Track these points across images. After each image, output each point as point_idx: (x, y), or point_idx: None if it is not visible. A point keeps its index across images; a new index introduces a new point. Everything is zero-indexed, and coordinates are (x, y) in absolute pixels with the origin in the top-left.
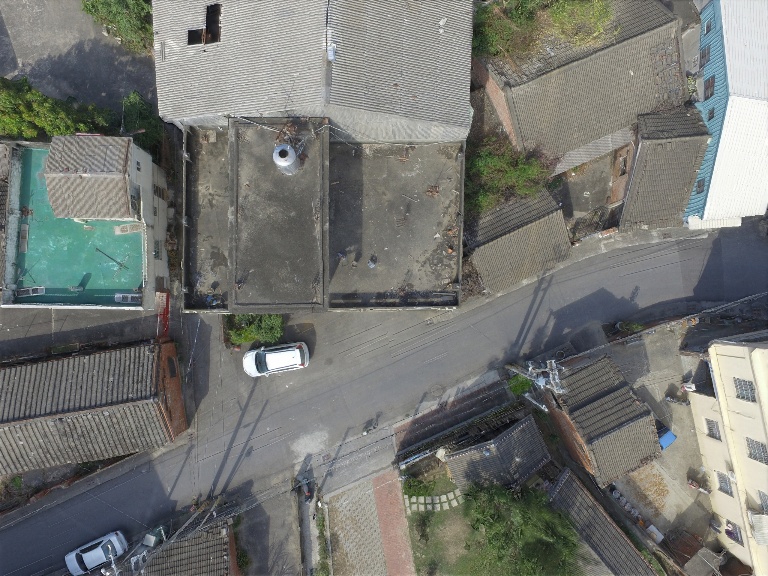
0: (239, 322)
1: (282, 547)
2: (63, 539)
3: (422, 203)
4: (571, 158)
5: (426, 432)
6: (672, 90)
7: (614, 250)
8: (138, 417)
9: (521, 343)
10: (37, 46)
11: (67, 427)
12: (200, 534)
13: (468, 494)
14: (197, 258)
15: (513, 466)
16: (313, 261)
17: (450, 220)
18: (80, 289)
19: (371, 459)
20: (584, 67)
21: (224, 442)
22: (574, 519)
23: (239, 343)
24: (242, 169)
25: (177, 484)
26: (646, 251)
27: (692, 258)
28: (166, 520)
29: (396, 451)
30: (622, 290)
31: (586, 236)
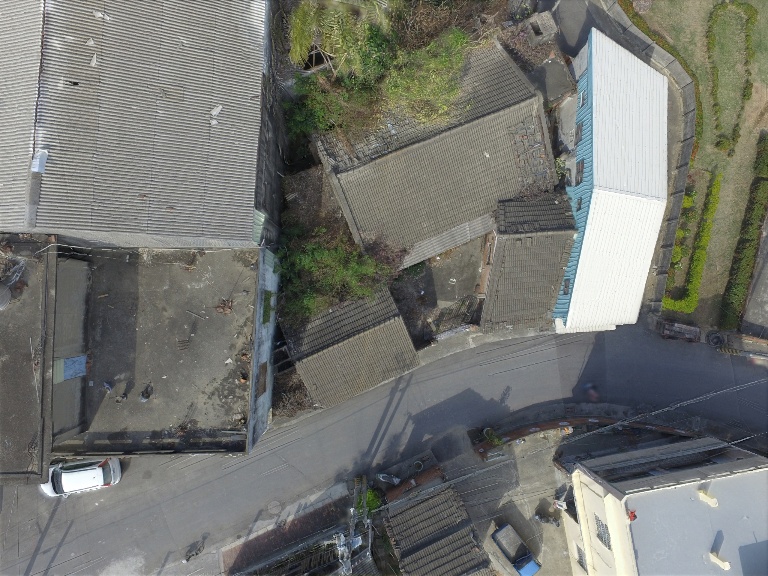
0: None
1: None
2: None
3: (211, 321)
4: (422, 249)
5: None
6: (538, 173)
7: (484, 345)
8: None
9: (374, 452)
10: None
11: None
12: None
13: None
14: None
15: None
16: (30, 418)
17: (245, 342)
18: None
19: None
20: (428, 149)
21: (19, 571)
22: None
23: None
24: None
25: None
26: (520, 346)
27: (571, 354)
28: None
29: None
30: (491, 391)
31: None
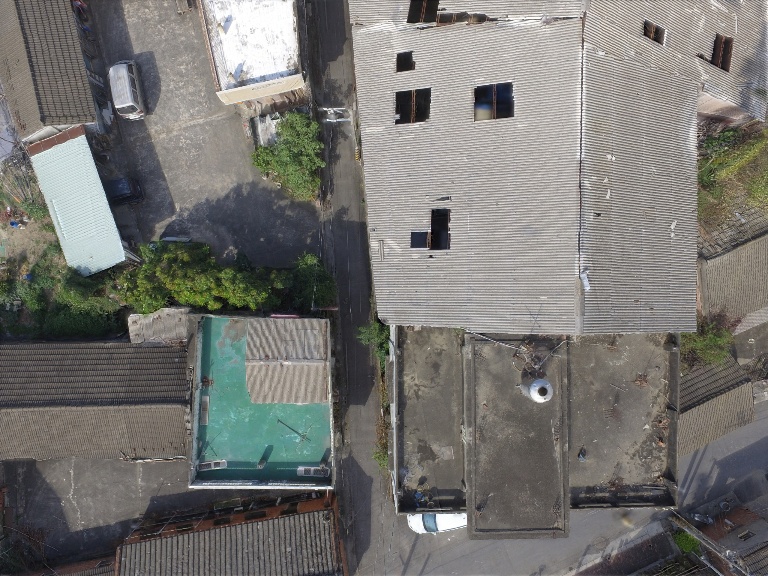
0: None
1: None
2: None
3: (631, 393)
4: (751, 318)
5: None
6: None
7: None
8: None
9: (684, 493)
10: (194, 190)
11: None
12: None
13: None
14: (404, 452)
15: None
16: (553, 484)
17: (659, 410)
18: (264, 464)
19: None
20: None
21: None
22: None
23: None
24: (479, 388)
25: None
26: None
27: None
28: None
29: None
30: None
31: (760, 392)
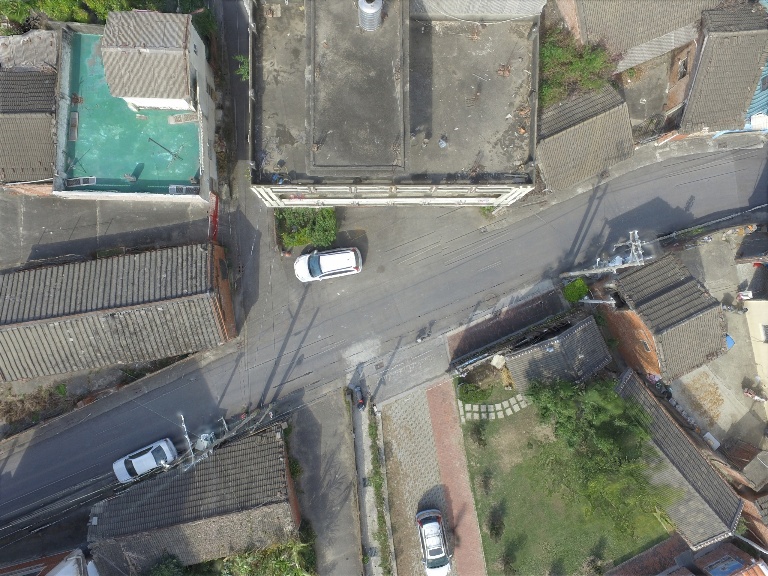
0: (290, 227)
1: (334, 456)
2: (110, 448)
3: (493, 83)
4: (633, 55)
5: (480, 341)
6: None
7: (669, 159)
8: (193, 314)
9: (576, 252)
10: None
11: (119, 324)
12: (254, 438)
13: (529, 394)
14: (262, 136)
15: (577, 363)
16: (393, 123)
17: (522, 101)
18: (133, 178)
19: (425, 367)
20: None
21: (275, 350)
22: (638, 416)
23: (289, 249)
24: (319, 27)
25: (227, 392)
26: (701, 160)
27: (747, 168)
28: (216, 429)
29: (450, 360)
30: (677, 200)
31: None
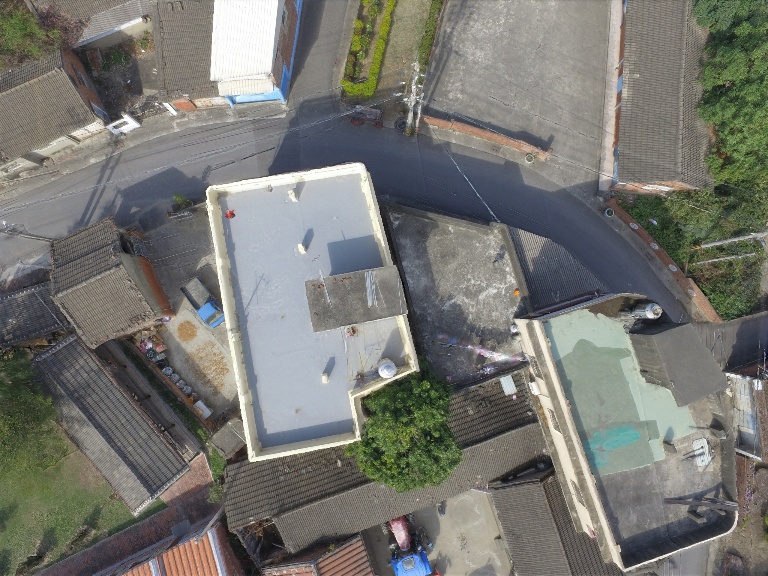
0: None
1: None
2: None
3: None
4: (98, 23)
5: None
6: None
7: (187, 129)
8: None
9: (86, 222)
10: None
11: None
12: None
13: None
14: None
15: (9, 328)
16: None
17: None
18: None
19: None
20: None
21: None
22: (67, 380)
23: None
24: None
25: None
26: (220, 130)
27: None
28: None
29: None
30: (194, 169)
31: None
